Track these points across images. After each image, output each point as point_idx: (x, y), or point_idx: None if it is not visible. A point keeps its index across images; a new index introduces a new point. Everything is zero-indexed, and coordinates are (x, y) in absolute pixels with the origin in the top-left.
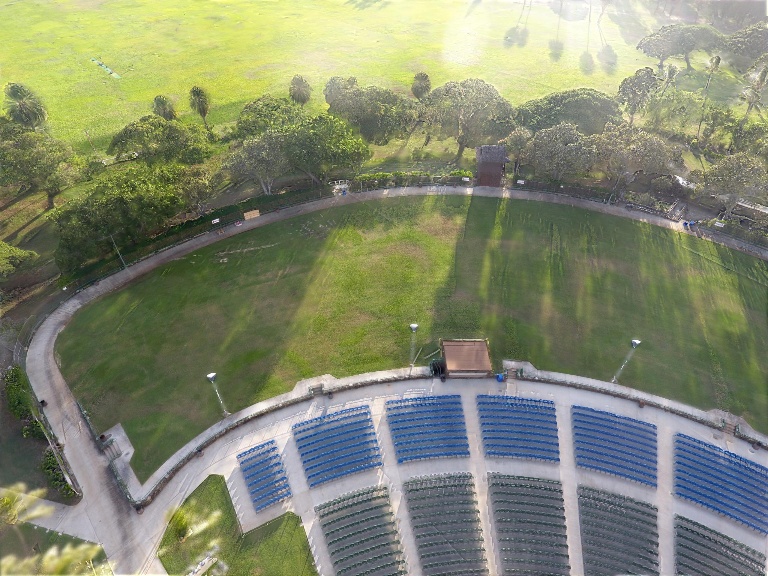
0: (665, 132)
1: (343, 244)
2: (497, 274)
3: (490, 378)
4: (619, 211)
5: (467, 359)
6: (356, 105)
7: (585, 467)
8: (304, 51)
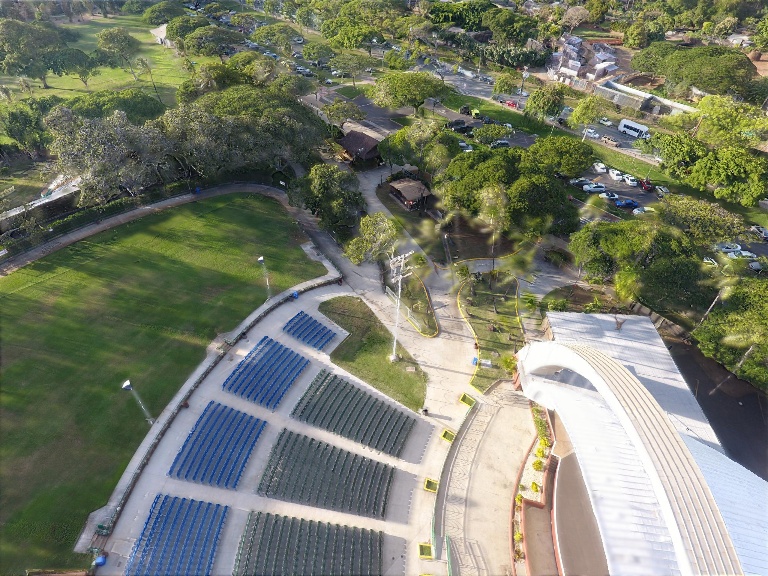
0: None
1: None
2: None
3: None
4: None
5: None
6: None
7: (238, 481)
8: None
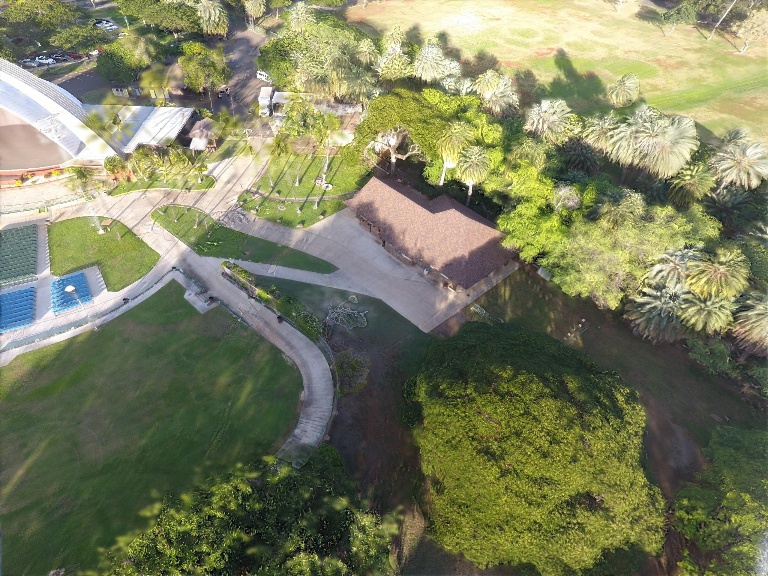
0: None
1: None
2: None
3: None
4: None
5: None
6: None
7: None
8: None
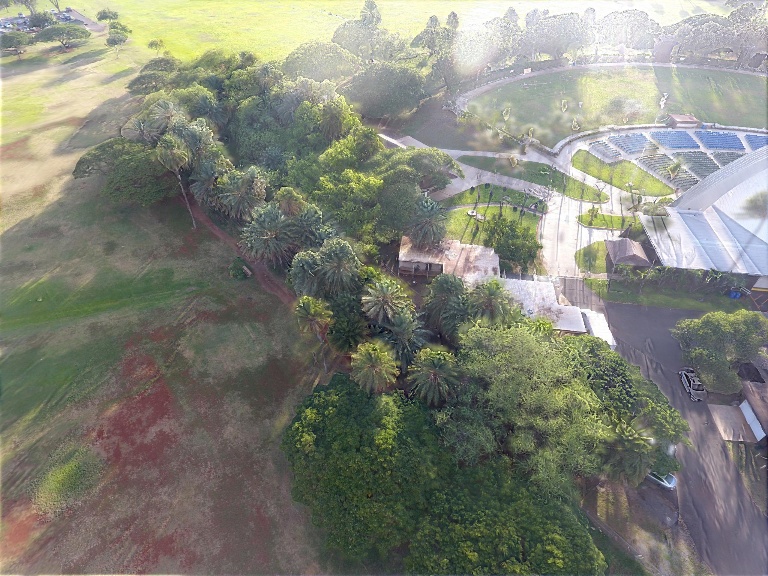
0: None
1: (588, 83)
2: (684, 95)
3: (698, 128)
4: (747, 72)
5: None
6: None
7: None
8: (470, 8)
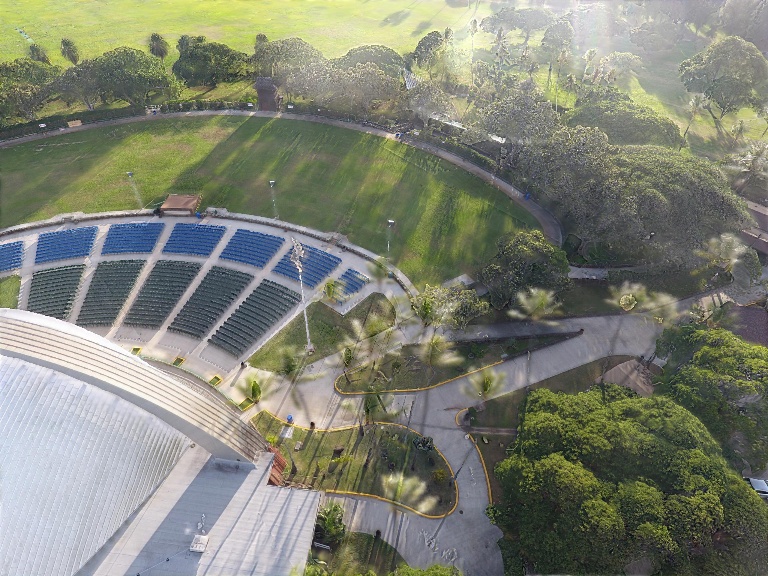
0: (449, 83)
1: (135, 143)
2: (237, 161)
3: (194, 216)
4: (355, 127)
5: (178, 203)
6: (192, 55)
7: (224, 258)
8: (202, 26)
